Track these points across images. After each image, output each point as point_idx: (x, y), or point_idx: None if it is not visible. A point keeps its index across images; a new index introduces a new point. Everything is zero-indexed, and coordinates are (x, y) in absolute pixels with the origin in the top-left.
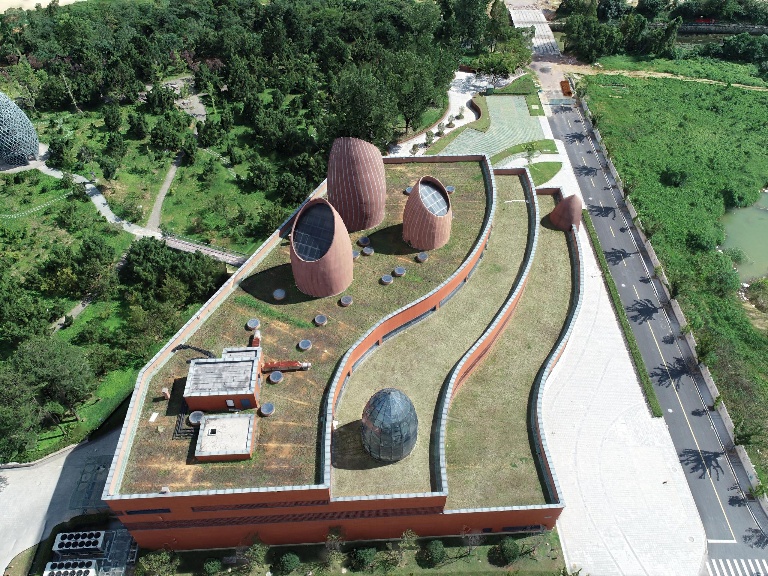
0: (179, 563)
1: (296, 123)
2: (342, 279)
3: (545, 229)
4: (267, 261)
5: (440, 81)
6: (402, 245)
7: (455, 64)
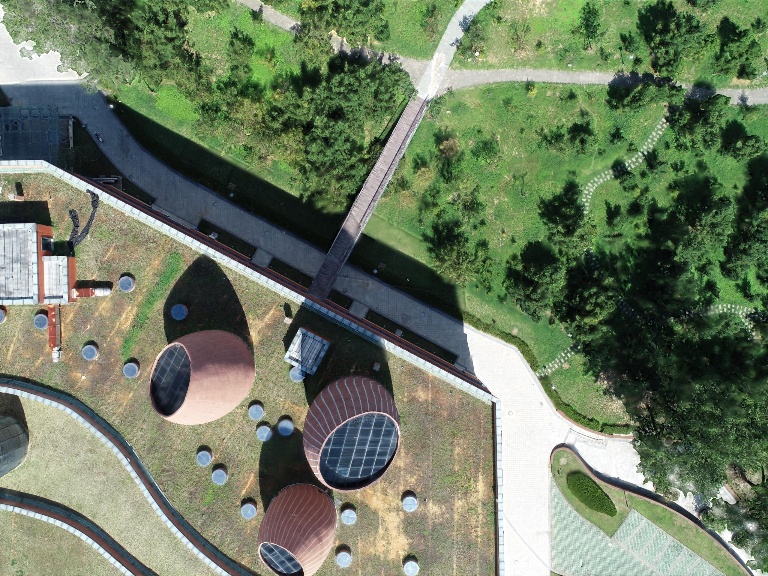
0: None
1: (764, 275)
2: None
3: None
4: (251, 287)
5: None
6: (279, 482)
7: None
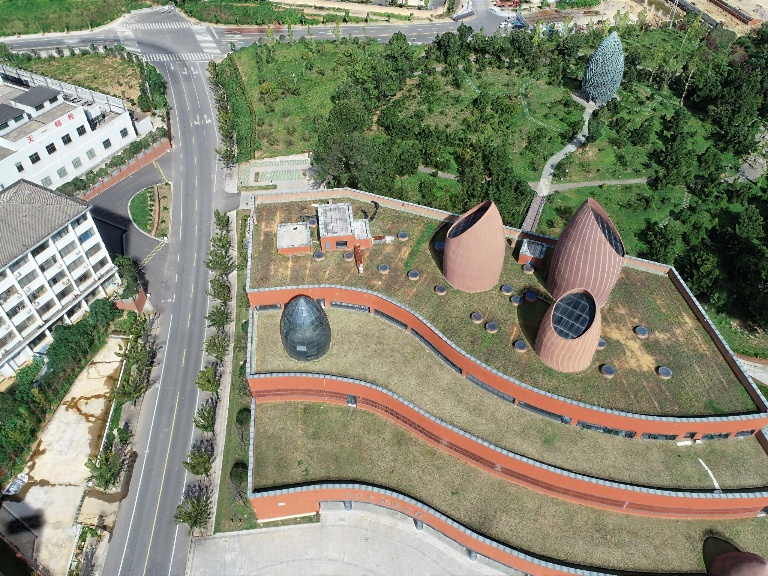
0: None
1: None
2: (455, 275)
3: (700, 542)
4: None
5: None
6: (537, 329)
7: None
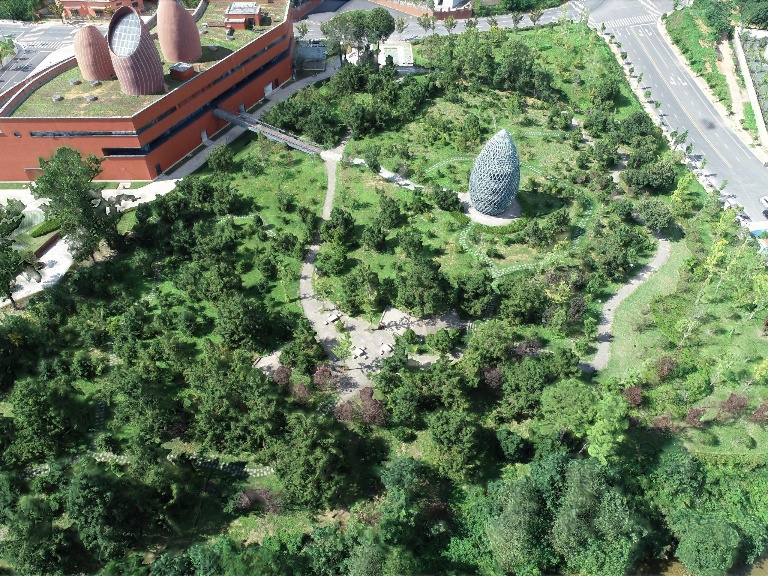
0: None
1: None
2: None
3: None
4: None
5: None
6: None
7: None
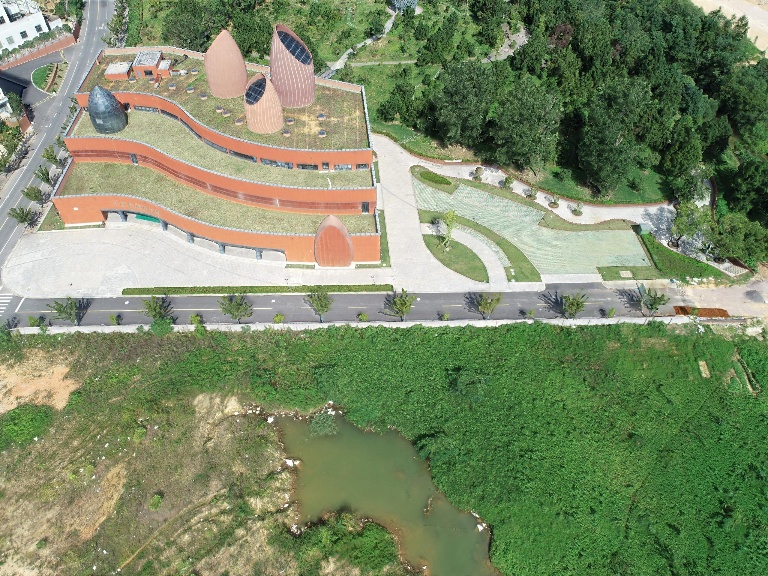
0: None
1: None
2: (211, 85)
3: None
4: (250, 72)
5: (601, 169)
6: None
7: (688, 195)
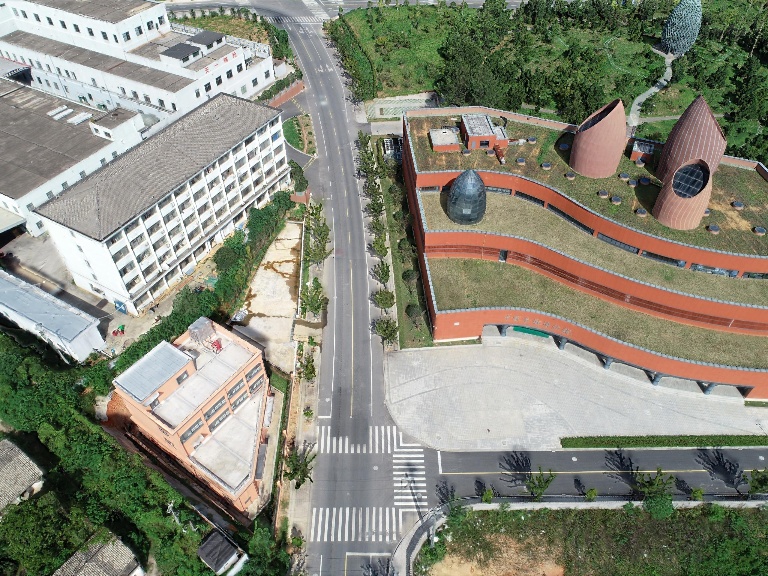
0: (393, 173)
1: None
2: (583, 163)
3: None
4: None
5: None
6: (653, 202)
7: None
